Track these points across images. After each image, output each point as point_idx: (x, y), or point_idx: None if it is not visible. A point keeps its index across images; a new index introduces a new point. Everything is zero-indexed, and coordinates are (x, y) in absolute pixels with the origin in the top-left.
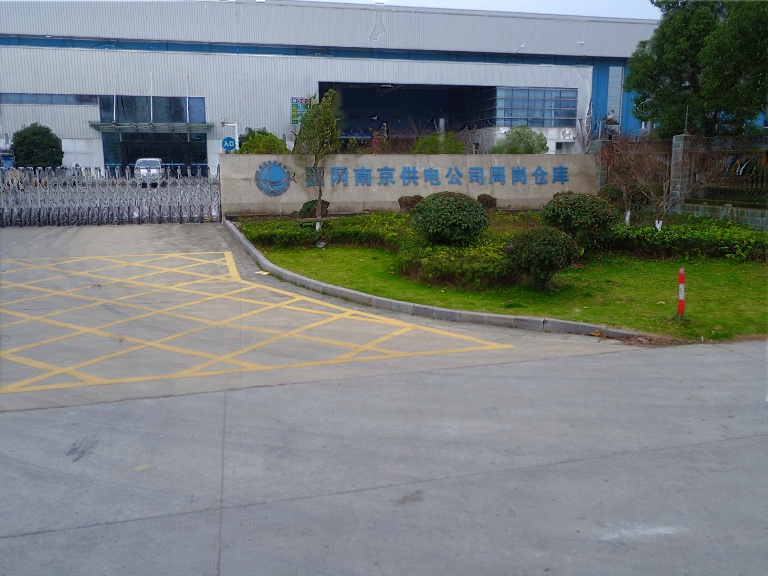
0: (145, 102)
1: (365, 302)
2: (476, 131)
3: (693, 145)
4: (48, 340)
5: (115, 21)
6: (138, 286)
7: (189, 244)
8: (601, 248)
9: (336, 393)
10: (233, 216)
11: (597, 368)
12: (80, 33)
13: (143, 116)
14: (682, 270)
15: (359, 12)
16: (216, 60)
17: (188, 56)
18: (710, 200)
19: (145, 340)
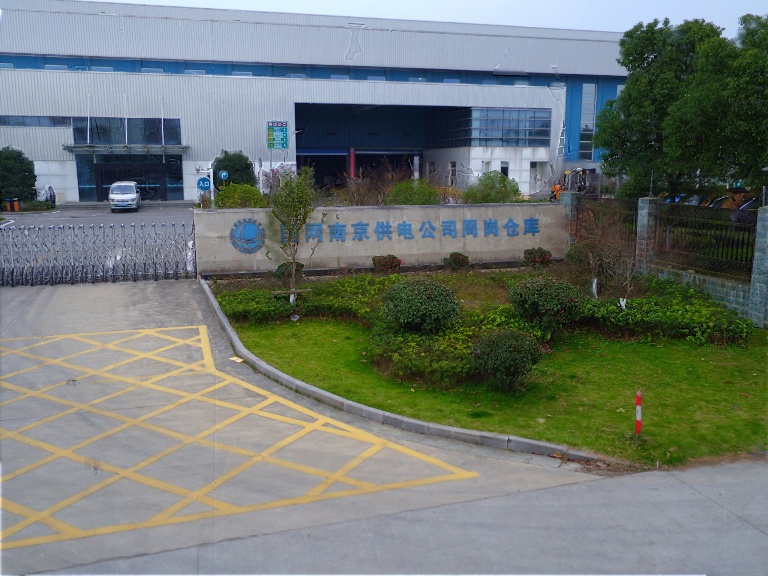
0: (119, 123)
1: (337, 406)
2: (452, 150)
3: (658, 208)
4: (23, 469)
5: (88, 39)
6: (113, 382)
7: (164, 314)
8: (568, 325)
9: (305, 551)
10: (208, 275)
11: (556, 510)
12: (53, 51)
13: (117, 138)
14: (639, 393)
15: (335, 30)
16: (191, 81)
17: (163, 77)
18: (674, 264)
19: (120, 468)
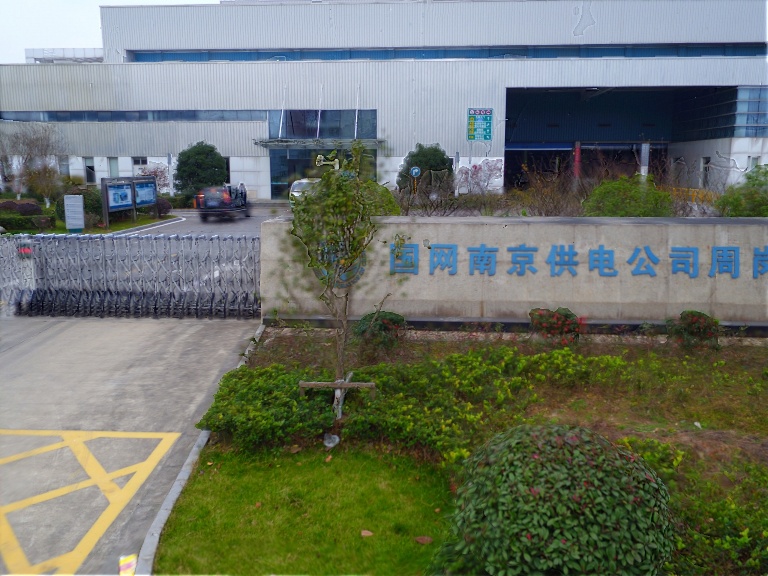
0: (314, 116)
1: None
2: (706, 142)
3: None
4: None
5: (299, 30)
6: None
7: (144, 396)
8: None
9: None
10: (272, 319)
11: None
12: (265, 45)
13: (311, 132)
14: None
15: (565, 3)
16: (391, 67)
17: (361, 64)
18: None
19: None
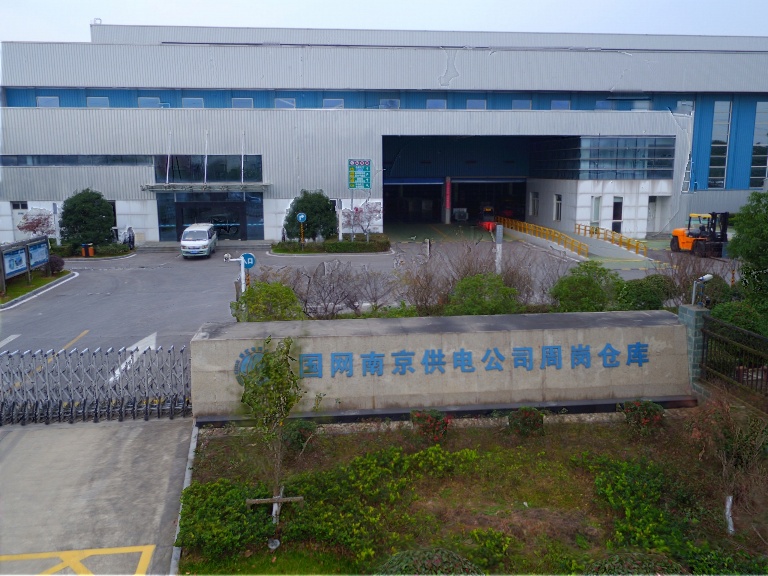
0: (200, 161)
1: None
2: (557, 181)
3: None
4: None
5: (179, 70)
6: None
7: (115, 510)
8: None
9: None
10: (203, 422)
11: None
12: (145, 84)
13: (198, 176)
14: None
15: (432, 52)
16: (274, 116)
17: (245, 112)
18: None
19: None
